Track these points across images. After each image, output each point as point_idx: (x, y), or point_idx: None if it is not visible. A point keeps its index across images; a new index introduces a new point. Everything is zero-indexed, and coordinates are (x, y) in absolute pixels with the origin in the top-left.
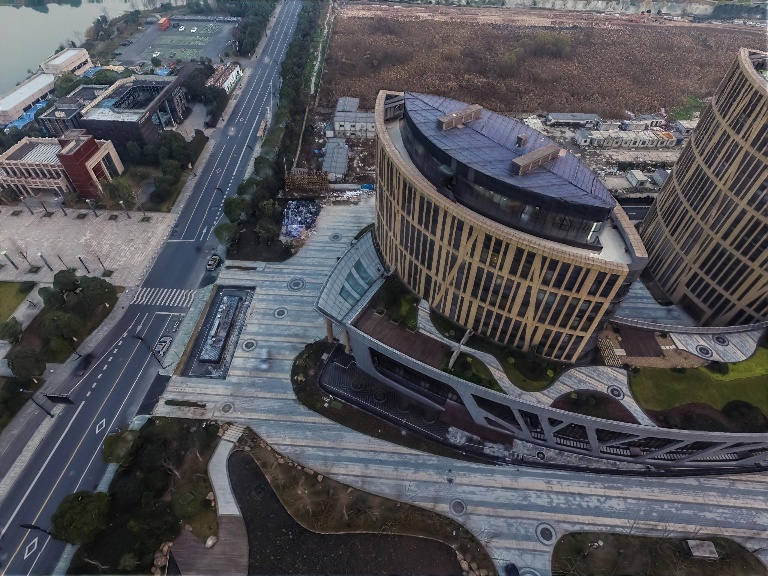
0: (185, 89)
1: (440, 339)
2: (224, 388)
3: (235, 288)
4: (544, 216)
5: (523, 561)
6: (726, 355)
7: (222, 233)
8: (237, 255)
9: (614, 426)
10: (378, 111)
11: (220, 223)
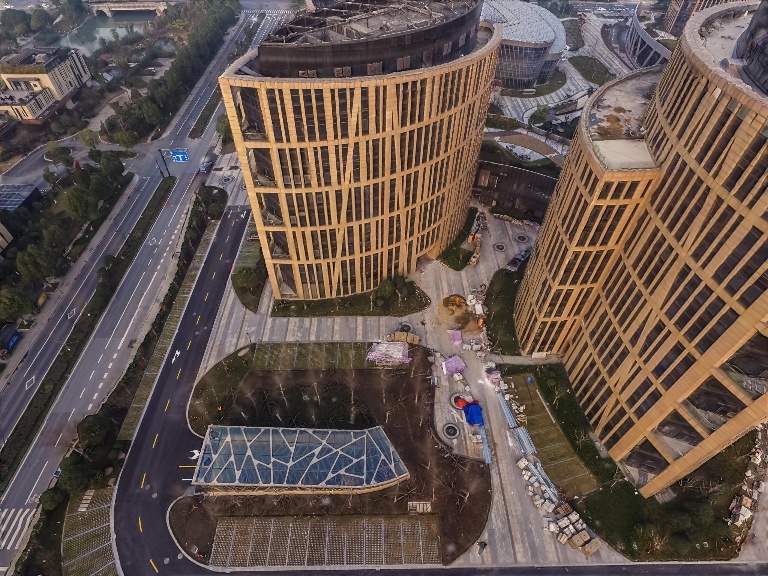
0: None
1: (652, 15)
2: (596, 18)
3: None
4: None
5: (581, 52)
6: None
7: None
8: None
9: None
10: None
11: None
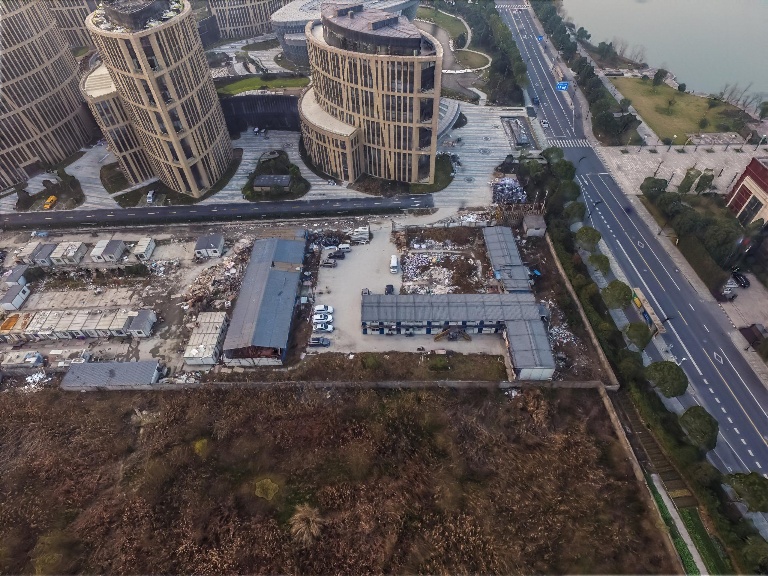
0: None
1: None
2: (498, 114)
3: None
4: None
5: None
6: (255, 91)
7: None
8: None
9: None
10: (440, 46)
11: None
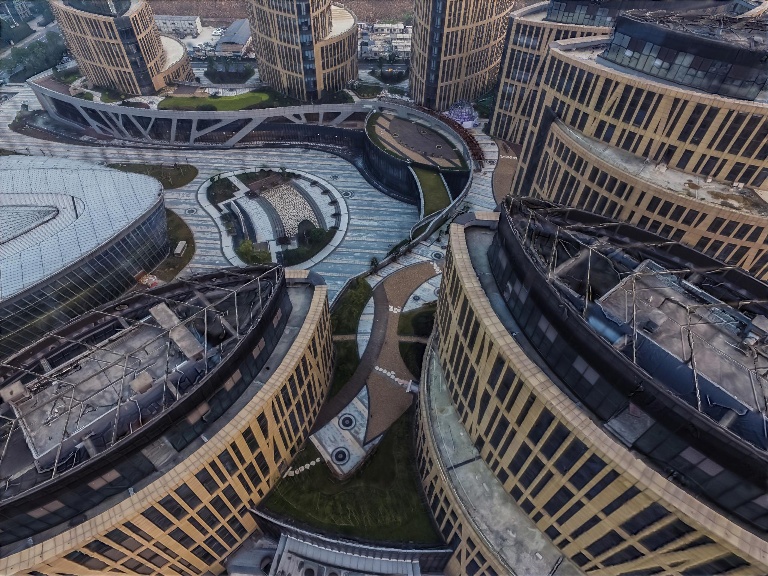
0: (32, 4)
1: (78, 88)
2: None
3: (6, 94)
4: (88, 0)
5: None
6: (226, 94)
7: (1, 63)
8: (15, 80)
9: (135, 111)
10: None
11: (16, 68)
